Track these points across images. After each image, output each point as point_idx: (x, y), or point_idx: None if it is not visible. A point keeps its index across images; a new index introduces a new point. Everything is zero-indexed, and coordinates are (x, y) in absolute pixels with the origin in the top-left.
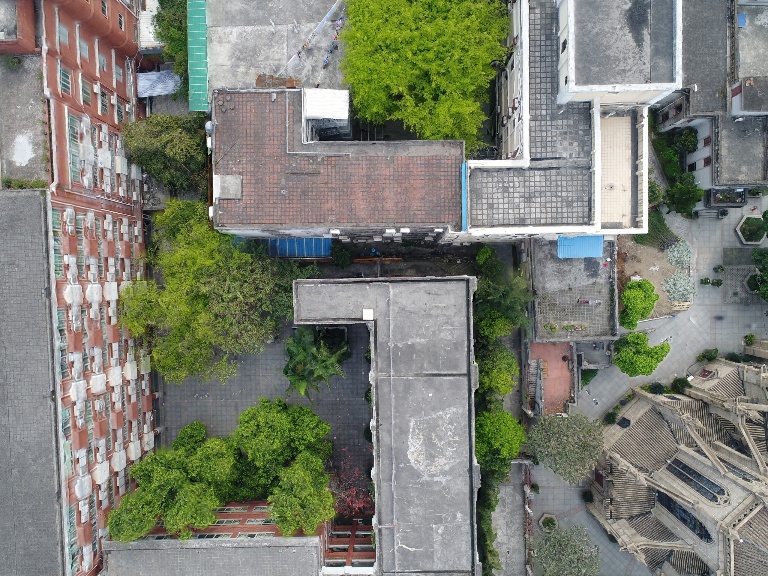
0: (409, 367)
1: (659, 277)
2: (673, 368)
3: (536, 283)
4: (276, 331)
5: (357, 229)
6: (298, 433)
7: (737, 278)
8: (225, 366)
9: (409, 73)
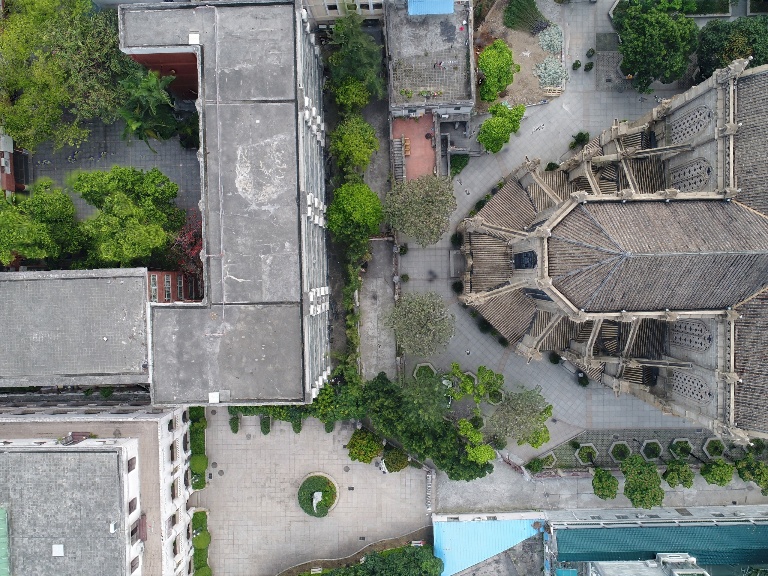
0: (236, 93)
1: (530, 63)
2: (546, 157)
3: (392, 49)
4: None
5: None
6: (143, 189)
7: (611, 64)
8: (76, 131)
9: None
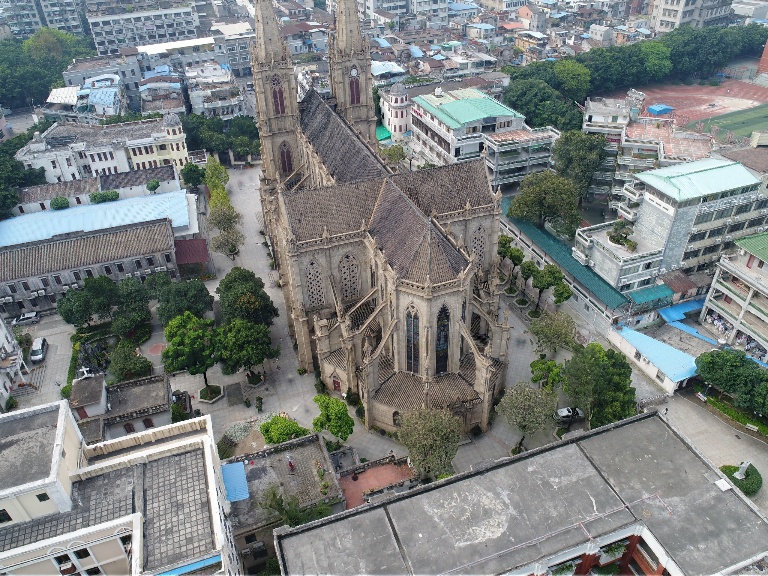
0: (398, 569)
1: (262, 440)
2: None
3: None
4: None
5: None
6: None
7: (253, 392)
8: None
9: None
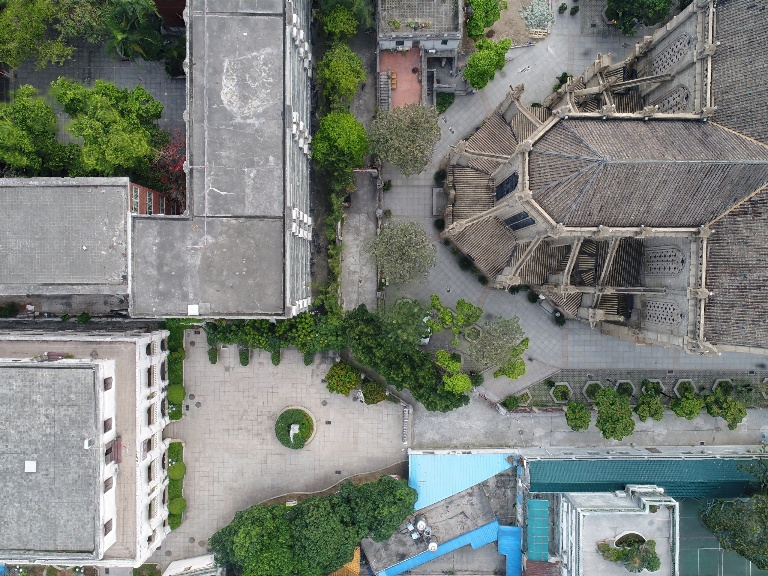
0: (224, 5)
1: (518, 4)
2: (530, 98)
3: None
4: (117, 21)
5: None
6: (127, 106)
7: (596, 9)
8: (60, 48)
9: None
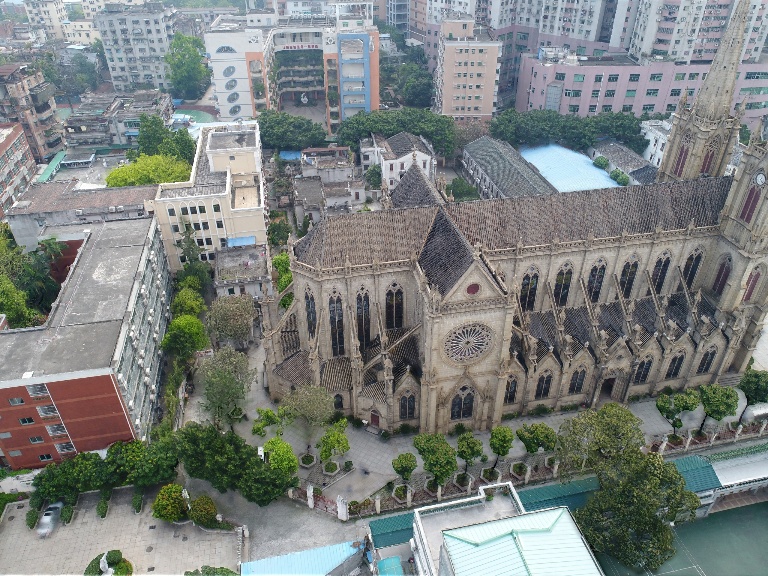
0: None
1: None
2: None
3: None
4: (30, 300)
5: (93, 213)
6: None
7: None
8: None
9: (139, 175)
